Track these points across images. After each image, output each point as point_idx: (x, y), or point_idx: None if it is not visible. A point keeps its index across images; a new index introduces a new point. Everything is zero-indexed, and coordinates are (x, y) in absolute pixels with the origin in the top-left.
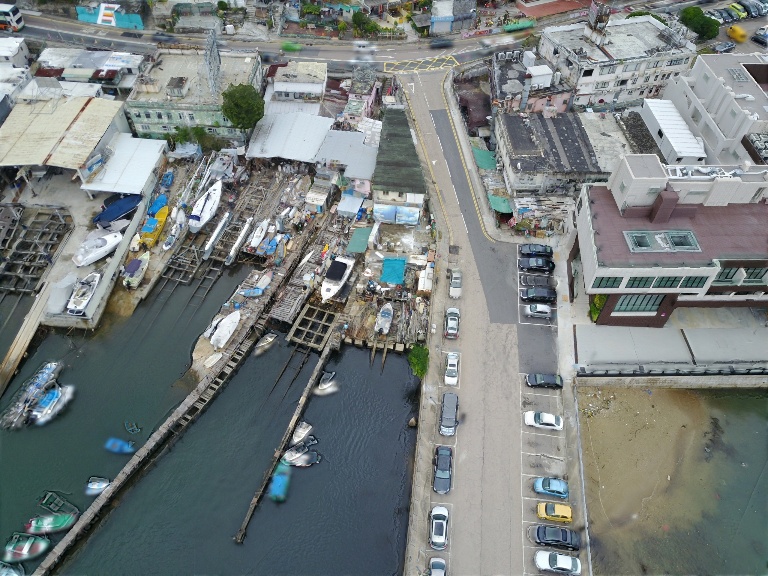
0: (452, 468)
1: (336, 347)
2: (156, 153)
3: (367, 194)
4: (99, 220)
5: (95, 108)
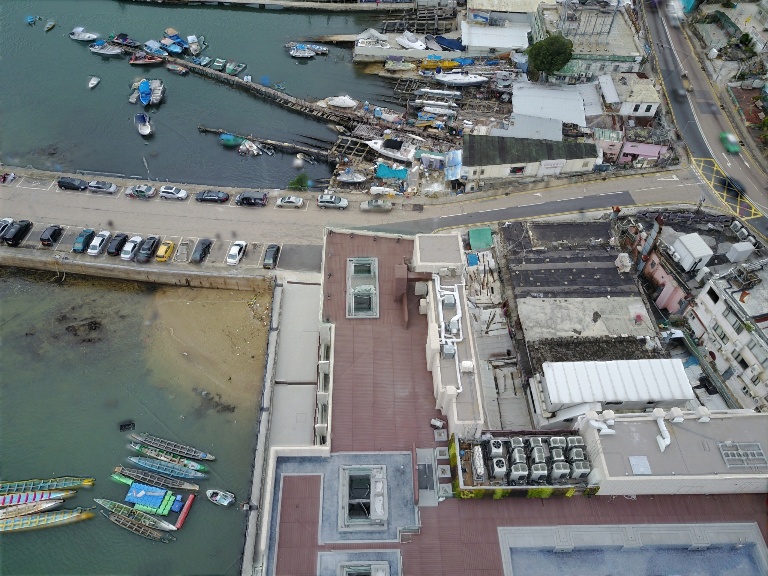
0: (212, 203)
1: (329, 157)
2: (511, 45)
3: None
4: (437, 38)
5: (540, 1)
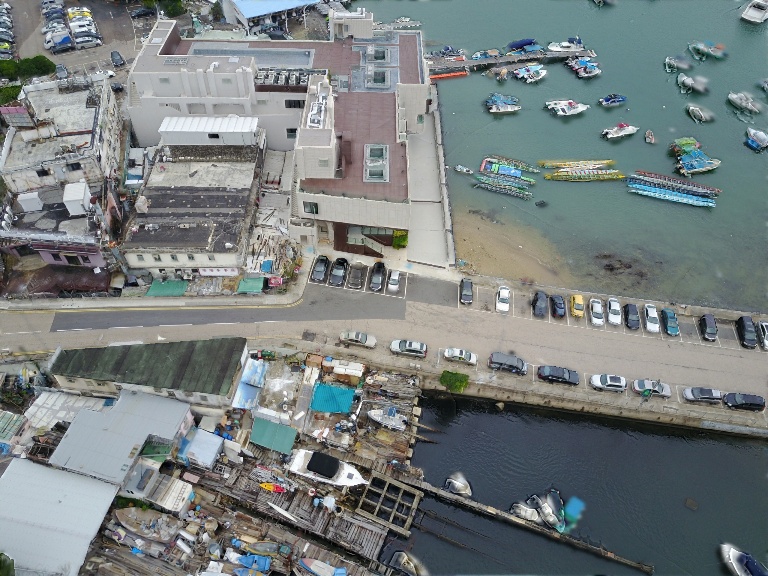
0: None
1: None
2: None
3: (193, 423)
4: None
5: None
